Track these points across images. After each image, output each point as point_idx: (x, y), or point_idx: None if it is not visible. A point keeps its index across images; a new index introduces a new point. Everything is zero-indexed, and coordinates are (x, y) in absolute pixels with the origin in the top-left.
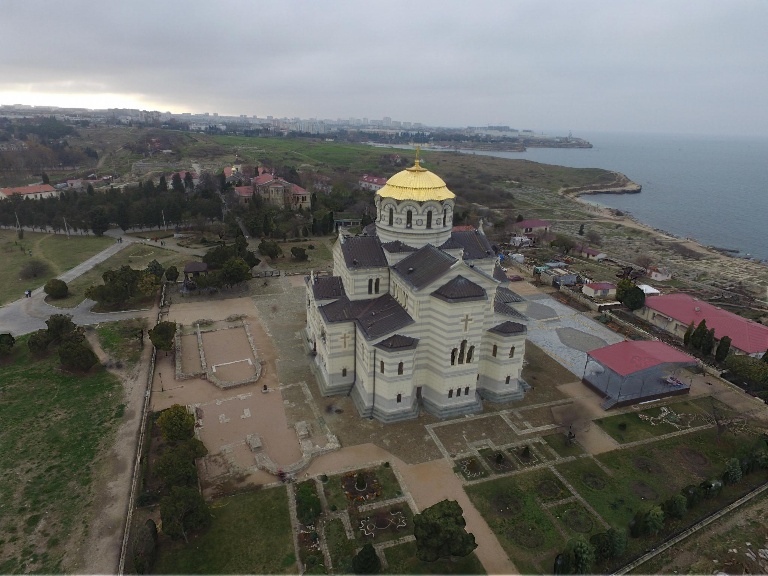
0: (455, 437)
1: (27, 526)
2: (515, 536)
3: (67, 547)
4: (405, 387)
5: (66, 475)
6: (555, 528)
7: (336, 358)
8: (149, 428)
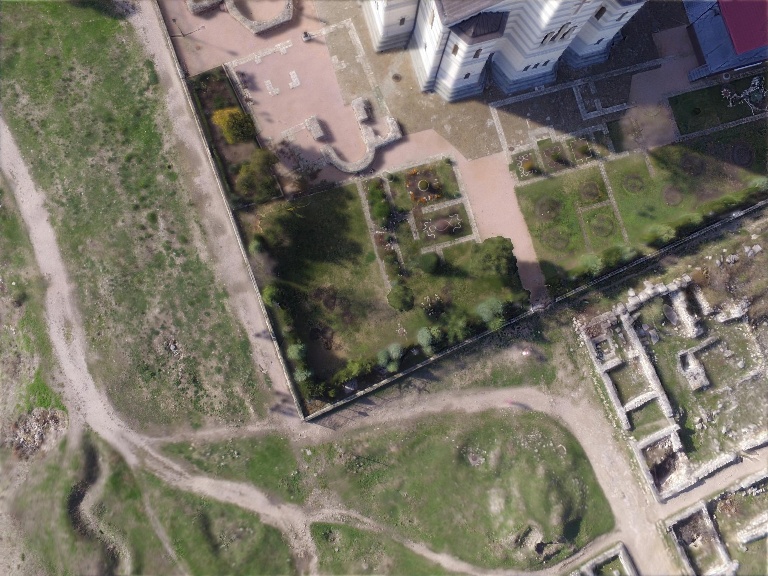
0: (518, 122)
1: (151, 223)
2: (547, 239)
3: (195, 244)
4: (477, 67)
5: (148, 167)
6: (581, 232)
7: (394, 10)
8: (199, 107)
